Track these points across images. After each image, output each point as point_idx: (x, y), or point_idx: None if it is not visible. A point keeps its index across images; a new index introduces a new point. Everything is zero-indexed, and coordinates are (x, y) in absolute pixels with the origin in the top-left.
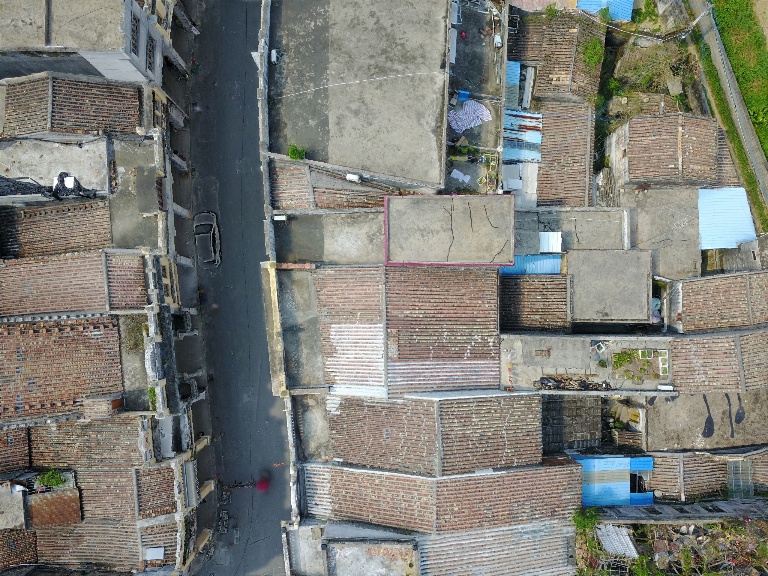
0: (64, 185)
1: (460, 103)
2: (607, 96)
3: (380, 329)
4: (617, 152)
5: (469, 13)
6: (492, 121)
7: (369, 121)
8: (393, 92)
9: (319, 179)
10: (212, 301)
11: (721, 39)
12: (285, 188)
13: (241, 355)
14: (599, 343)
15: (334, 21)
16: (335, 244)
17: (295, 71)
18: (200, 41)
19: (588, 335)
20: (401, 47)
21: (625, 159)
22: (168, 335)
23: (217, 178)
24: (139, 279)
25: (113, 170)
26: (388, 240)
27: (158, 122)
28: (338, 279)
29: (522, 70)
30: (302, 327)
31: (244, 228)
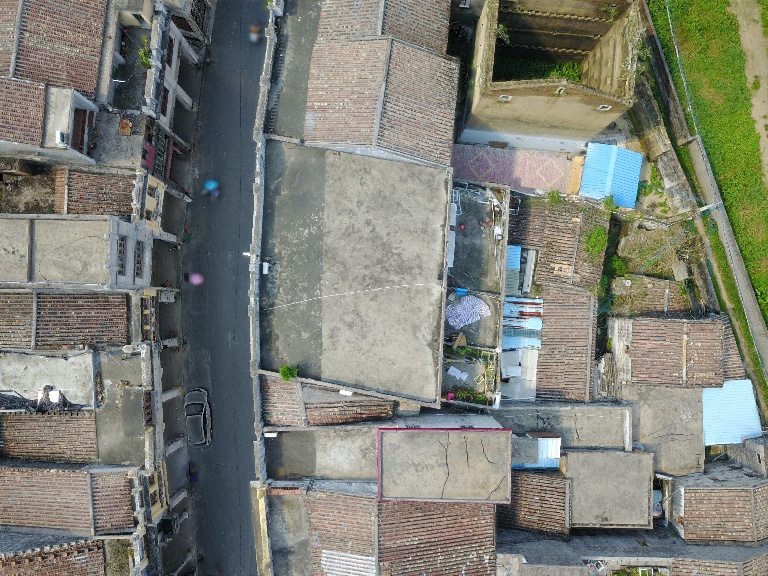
0: (49, 399)
1: (458, 297)
2: (610, 271)
3: (372, 562)
4: (620, 342)
5: (469, 203)
6: (491, 316)
7: (363, 334)
8: (389, 304)
9: (311, 395)
10: (203, 479)
11: (729, 215)
12: (276, 401)
13: (232, 535)
14: (598, 561)
15: (328, 229)
16: (327, 458)
17: (288, 281)
18: (192, 209)
19: (587, 545)
20: (397, 257)
21: (628, 356)
22: (154, 557)
23: (209, 351)
24: (125, 497)
25: (99, 384)
26: (381, 475)
27: (147, 320)
28: (330, 504)
29: (523, 252)
30: (292, 549)
31: (236, 404)
